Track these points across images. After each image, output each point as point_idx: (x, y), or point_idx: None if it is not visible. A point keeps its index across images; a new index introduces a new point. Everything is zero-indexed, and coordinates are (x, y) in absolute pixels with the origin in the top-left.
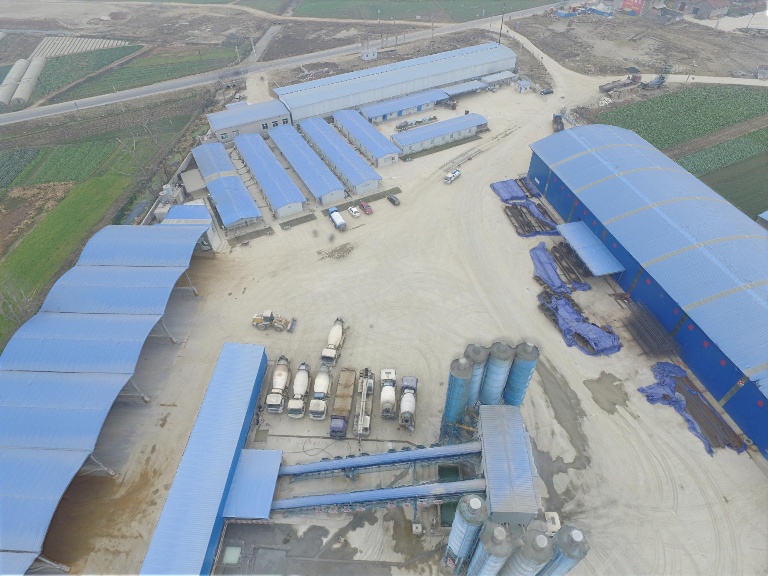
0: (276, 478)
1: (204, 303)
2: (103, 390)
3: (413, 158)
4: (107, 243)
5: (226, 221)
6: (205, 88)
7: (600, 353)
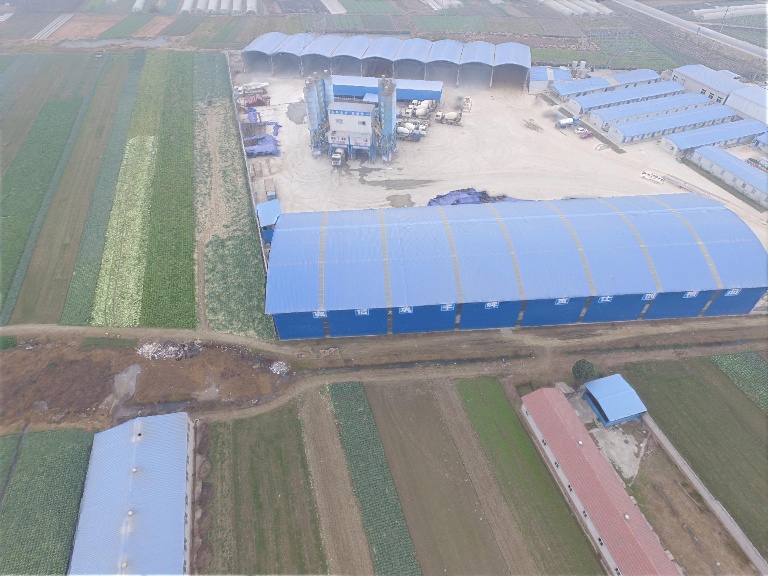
0: (377, 102)
1: (485, 90)
2: (417, 57)
3: (686, 164)
4: None
5: (553, 84)
6: (759, 60)
7: (429, 205)
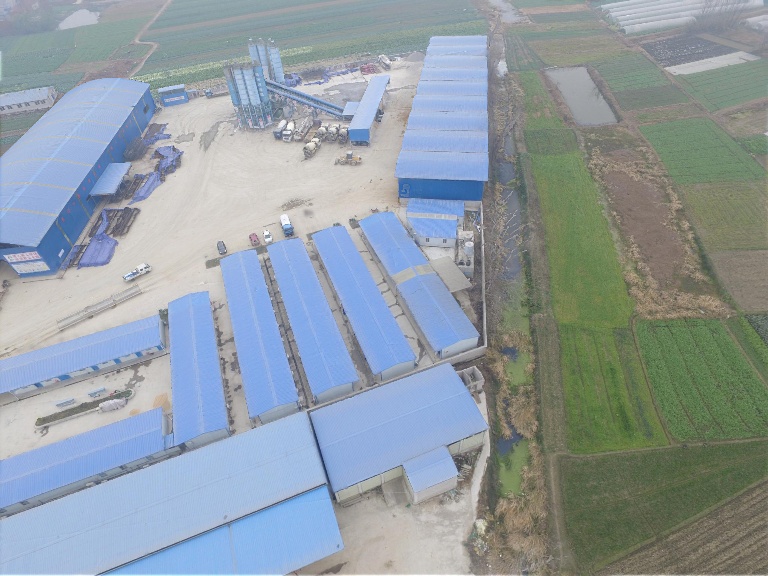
0: None
1: None
2: (421, 103)
3: None
4: (471, 158)
5: (392, 215)
6: None
7: None
